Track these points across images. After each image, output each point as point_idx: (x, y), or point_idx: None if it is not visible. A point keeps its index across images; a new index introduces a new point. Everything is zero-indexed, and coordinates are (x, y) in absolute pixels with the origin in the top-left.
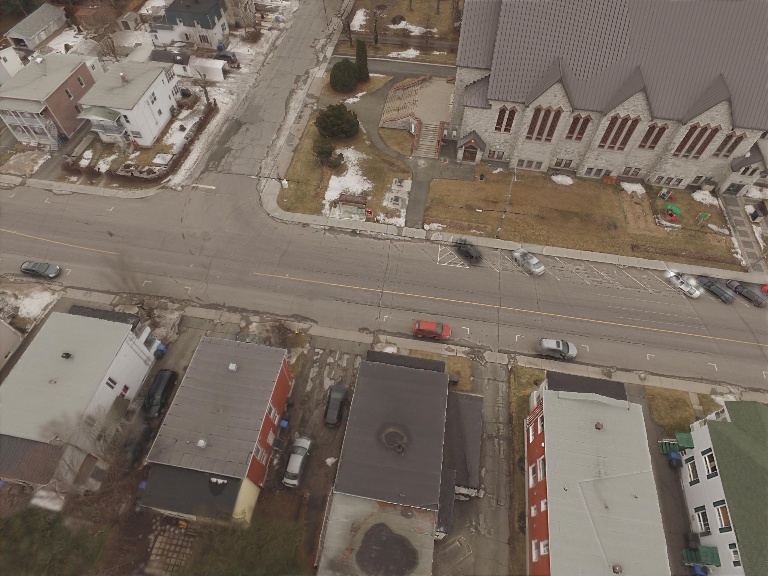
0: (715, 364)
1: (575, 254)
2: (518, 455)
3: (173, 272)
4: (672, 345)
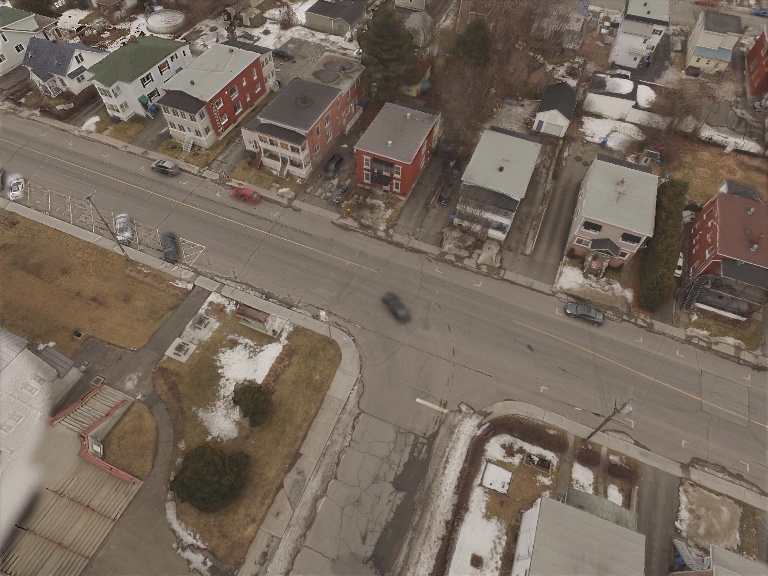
0: (68, 144)
1: (74, 230)
2: (237, 129)
3: (455, 289)
4: (82, 157)
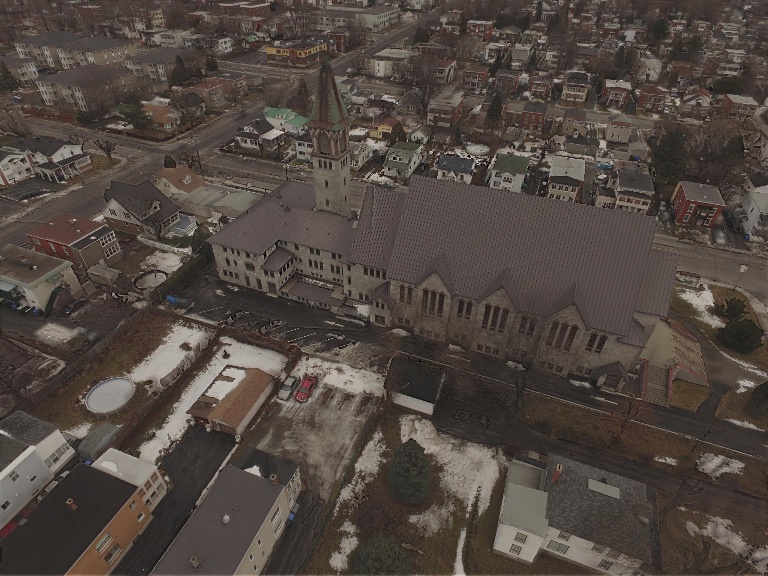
0: None
1: None
2: None
3: None
4: None
